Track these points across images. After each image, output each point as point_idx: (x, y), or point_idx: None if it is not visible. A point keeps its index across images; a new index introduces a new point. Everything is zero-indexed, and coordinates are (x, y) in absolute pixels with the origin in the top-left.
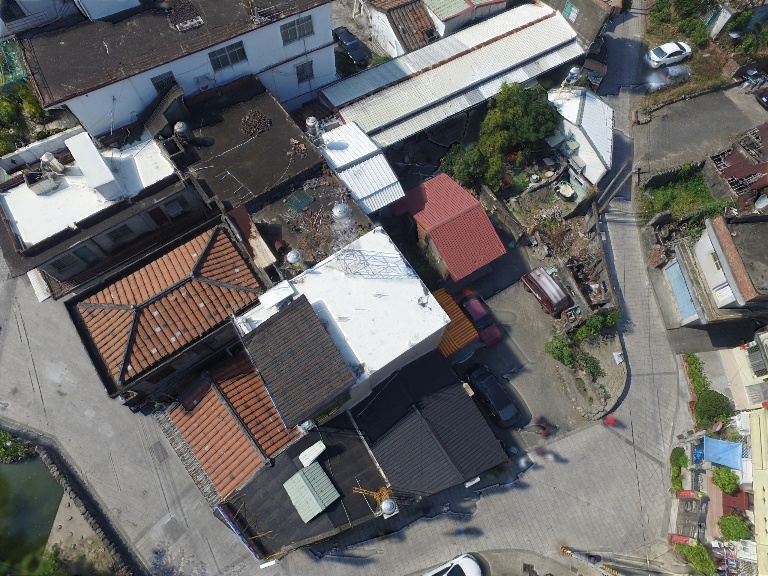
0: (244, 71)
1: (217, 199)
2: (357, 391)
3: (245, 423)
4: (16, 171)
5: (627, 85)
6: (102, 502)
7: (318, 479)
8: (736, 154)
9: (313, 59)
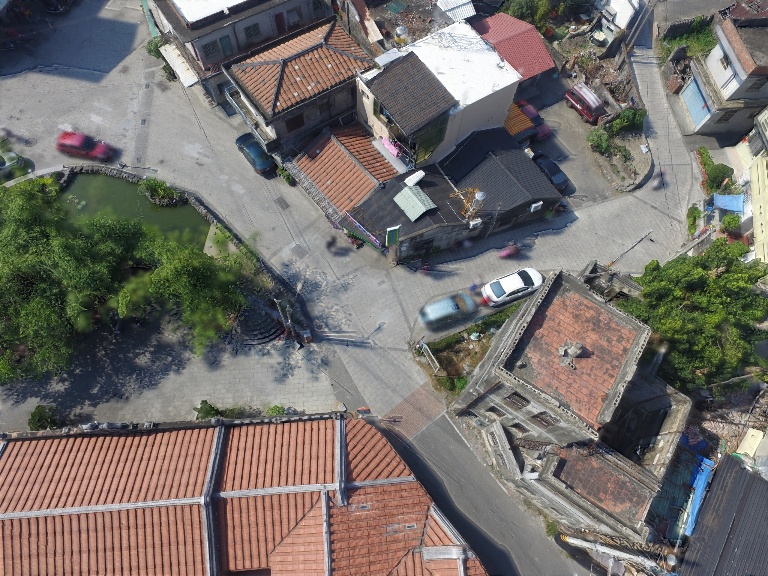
0: None
1: None
2: (451, 129)
3: (360, 161)
4: None
5: None
6: (240, 234)
7: (420, 194)
8: (739, 7)
9: None
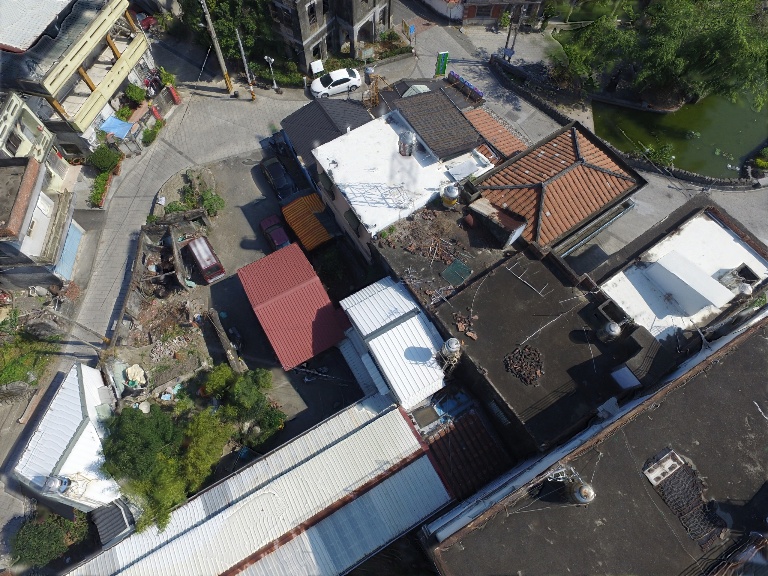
0: None
1: (541, 250)
2: None
3: None
4: None
5: None
6: None
7: None
8: None
9: None
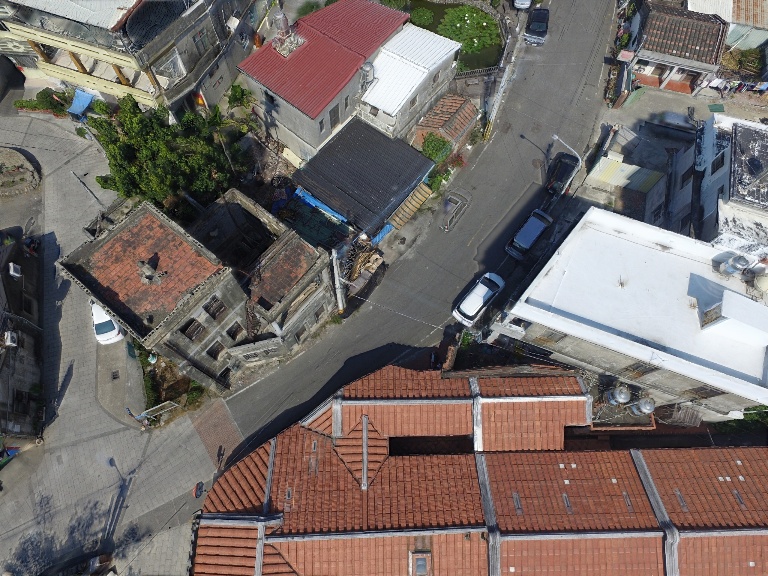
0: None
1: None
2: None
3: None
4: None
5: None
6: None
7: None
8: None
9: None
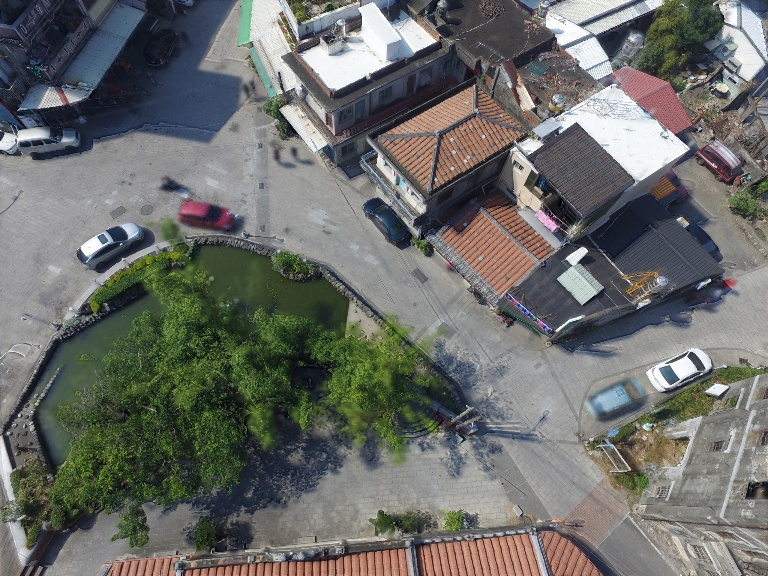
0: None
1: (483, 58)
2: None
3: None
4: (304, 39)
5: (754, 12)
6: (381, 311)
7: (586, 274)
8: None
9: None
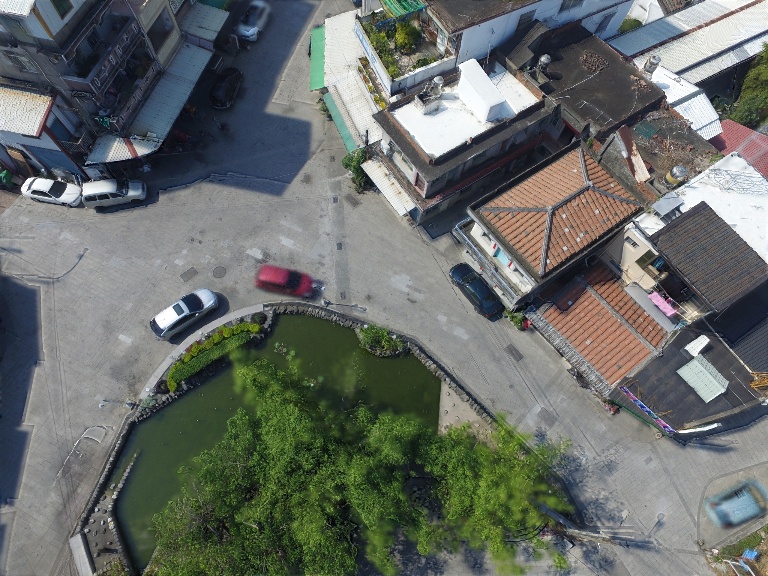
0: (573, 16)
1: (593, 122)
2: None
3: None
4: (395, 94)
5: None
6: (475, 393)
7: (708, 367)
8: None
9: (618, 11)
